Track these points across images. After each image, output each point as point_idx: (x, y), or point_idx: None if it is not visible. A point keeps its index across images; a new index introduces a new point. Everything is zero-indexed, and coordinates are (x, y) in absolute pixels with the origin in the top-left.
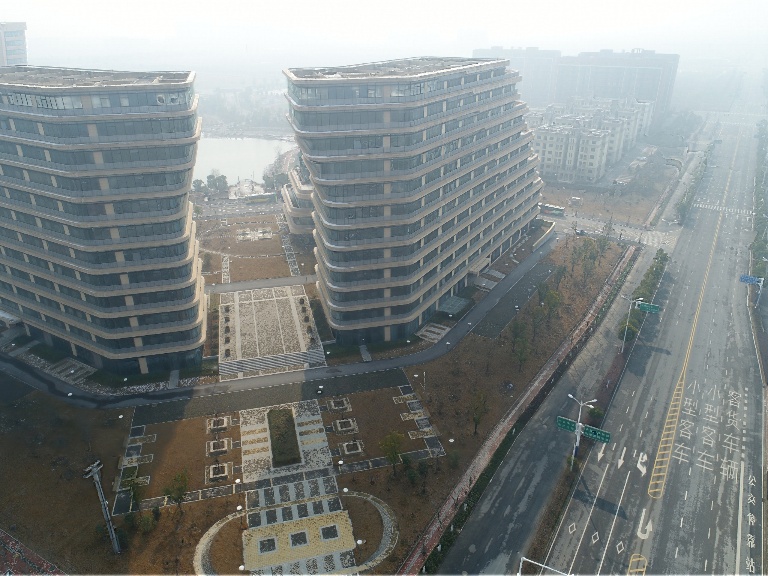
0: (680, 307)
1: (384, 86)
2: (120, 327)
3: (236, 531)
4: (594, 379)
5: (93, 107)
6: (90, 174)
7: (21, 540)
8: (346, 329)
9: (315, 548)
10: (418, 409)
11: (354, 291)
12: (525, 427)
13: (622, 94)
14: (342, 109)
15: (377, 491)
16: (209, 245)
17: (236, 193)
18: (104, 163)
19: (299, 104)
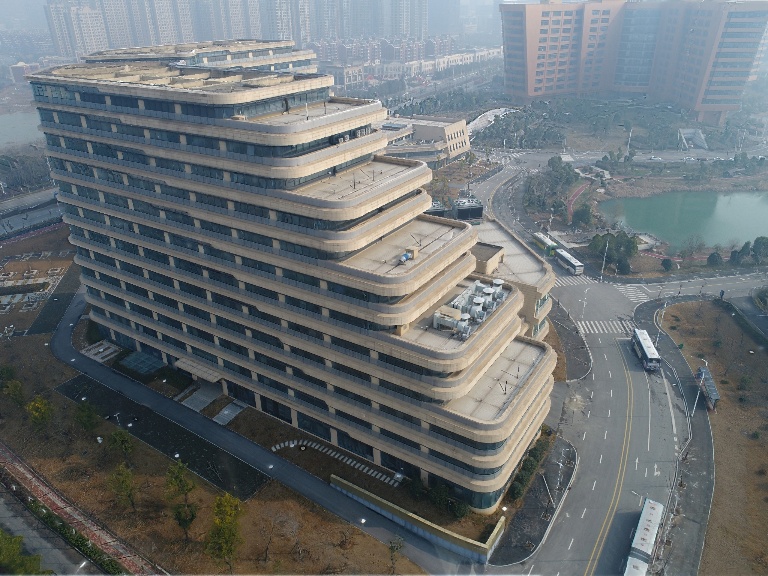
0: None
1: None
2: None
3: None
4: None
5: None
6: None
7: None
8: None
9: None
10: None
11: None
12: None
13: None
14: None
15: None
16: None
17: None
18: None
19: None
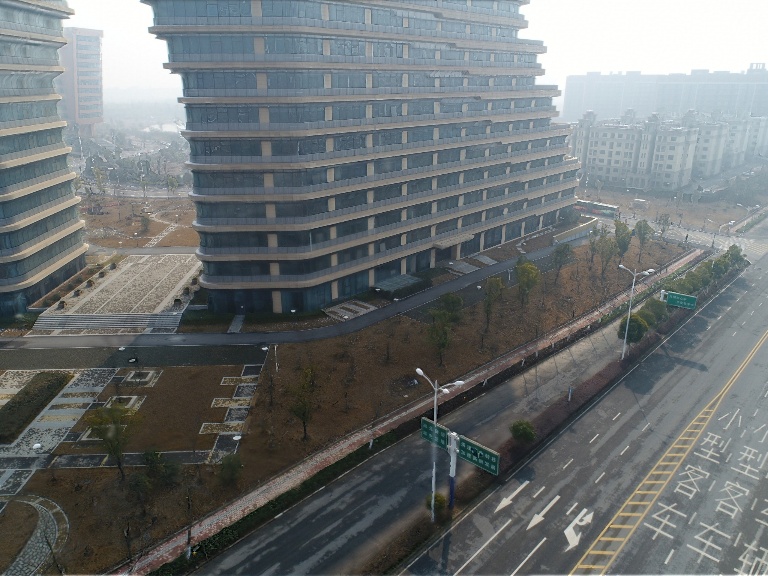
0: (747, 316)
1: None
2: None
3: None
4: (559, 389)
5: None
6: None
7: None
8: (214, 287)
9: None
10: (246, 395)
11: (222, 232)
12: (400, 441)
13: (732, 108)
14: None
15: (73, 502)
16: (166, 216)
17: None
18: None
19: None
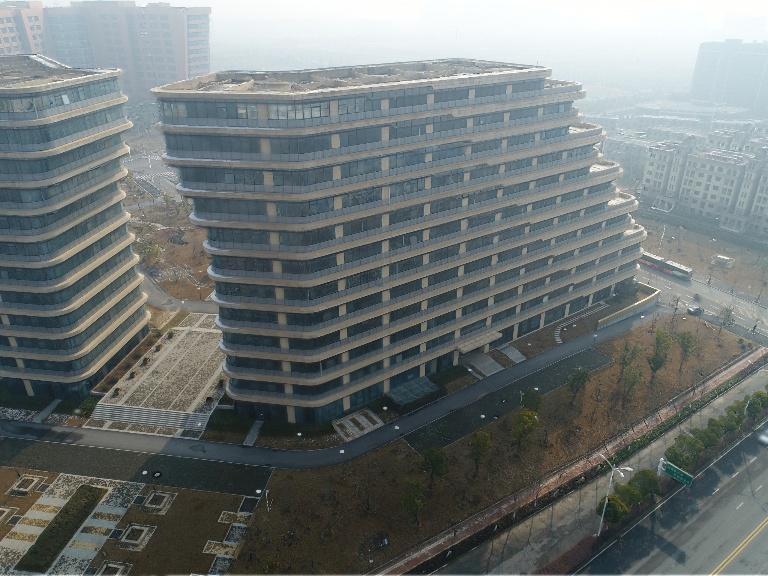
0: (767, 476)
1: (258, 104)
2: (1, 344)
3: None
4: (519, 570)
5: None
6: None
7: None
8: (236, 398)
9: None
10: (235, 540)
11: (242, 356)
12: None
13: None
14: (202, 131)
15: None
16: None
17: None
18: None
19: None
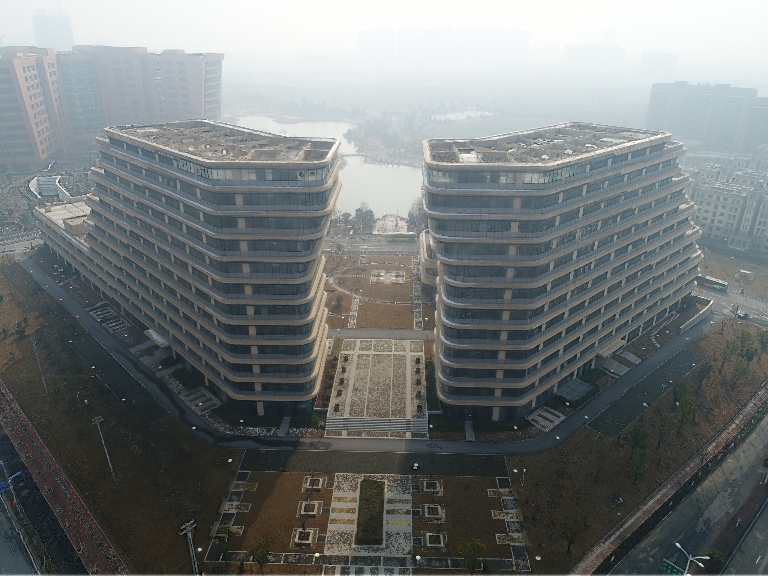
0: None
1: (517, 173)
2: (244, 372)
3: None
4: (723, 510)
5: (242, 179)
6: (233, 237)
7: (128, 567)
8: (453, 403)
9: None
10: (512, 509)
11: (465, 368)
12: (627, 555)
13: None
14: (471, 193)
15: None
16: (344, 284)
17: (380, 228)
18: (246, 228)
19: (429, 185)
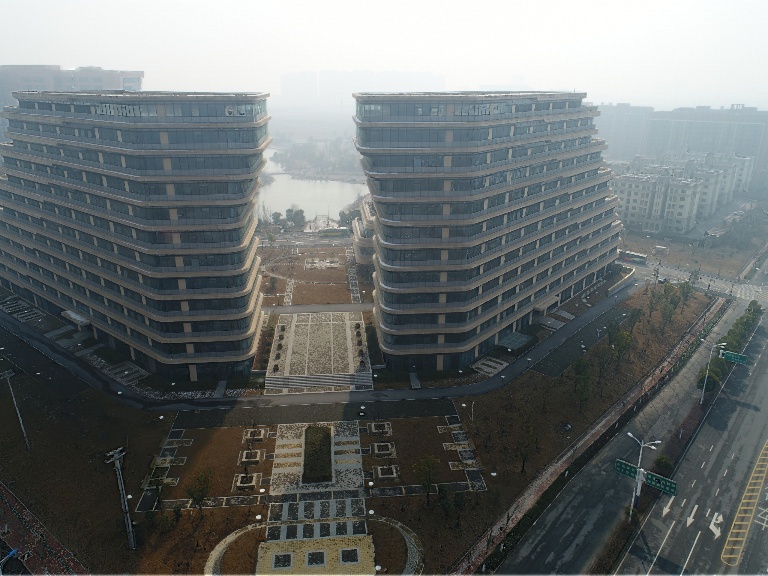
0: None
1: (447, 105)
2: (174, 332)
3: (253, 542)
4: (666, 429)
5: (166, 116)
6: (158, 179)
7: (46, 525)
8: (397, 353)
9: (332, 570)
10: (463, 440)
11: (407, 314)
12: (580, 471)
13: (719, 148)
14: (403, 126)
15: (407, 519)
16: (277, 270)
17: (311, 227)
18: (172, 169)
19: (362, 121)
